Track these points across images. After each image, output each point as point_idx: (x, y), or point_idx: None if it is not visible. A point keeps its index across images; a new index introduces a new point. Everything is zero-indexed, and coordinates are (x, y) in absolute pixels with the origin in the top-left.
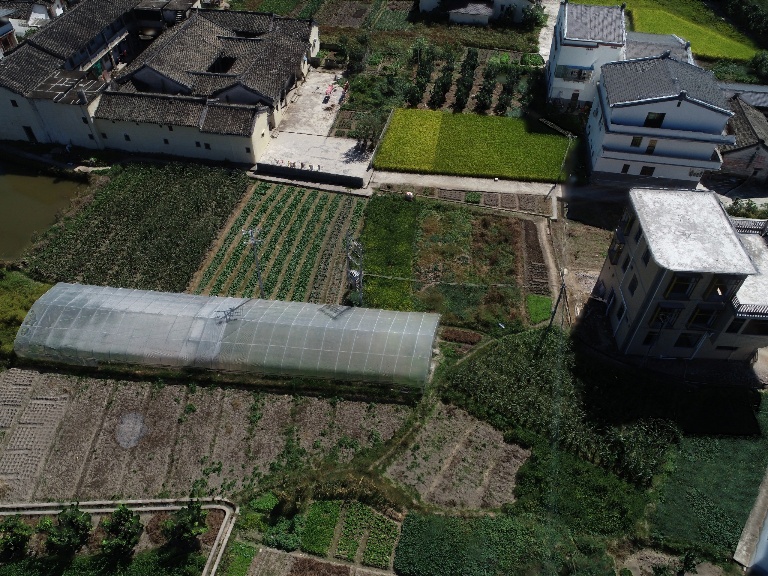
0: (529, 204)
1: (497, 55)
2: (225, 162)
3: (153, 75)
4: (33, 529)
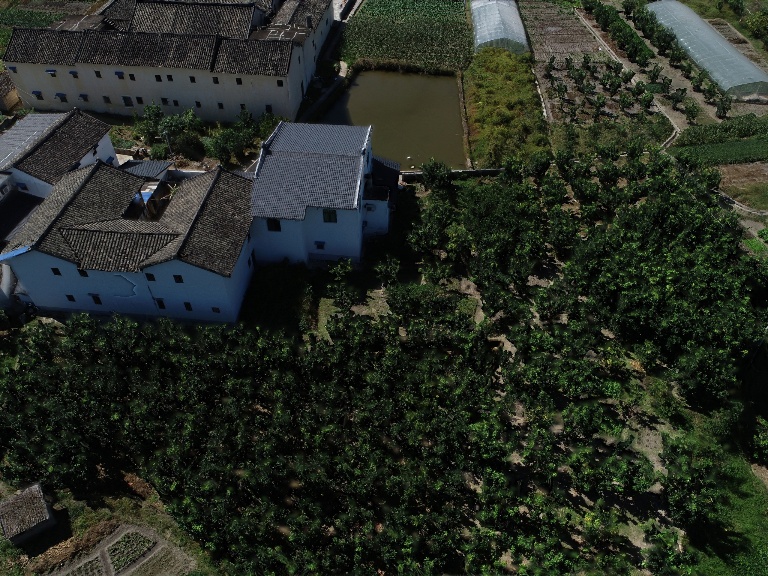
0: None
1: None
2: (334, 27)
3: (256, 14)
4: None
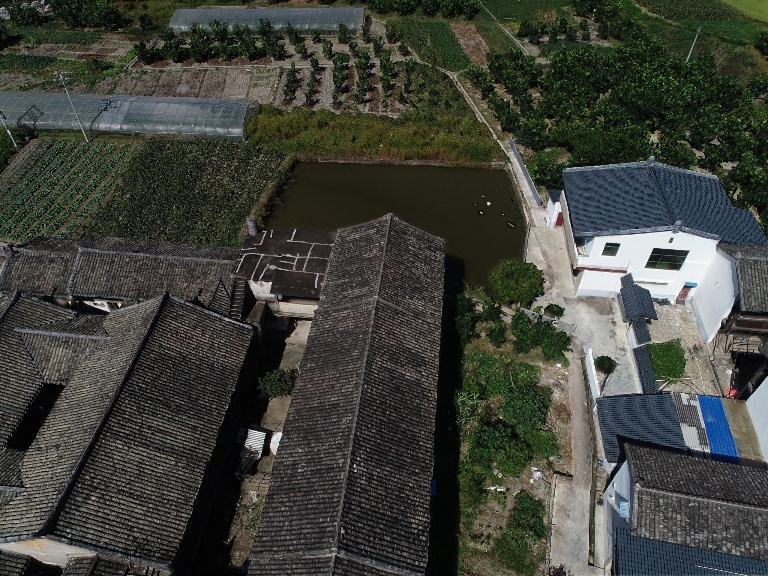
0: None
1: None
2: None
3: None
4: (215, 51)
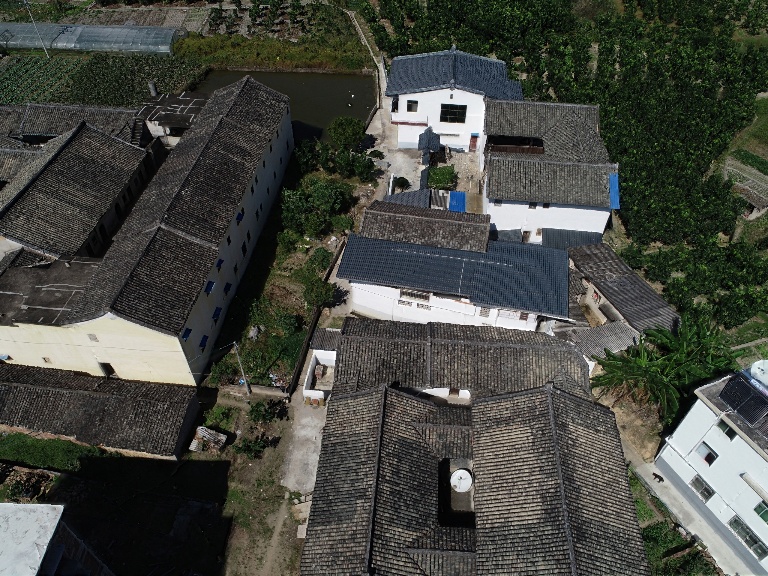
0: None
1: None
2: None
3: None
4: None
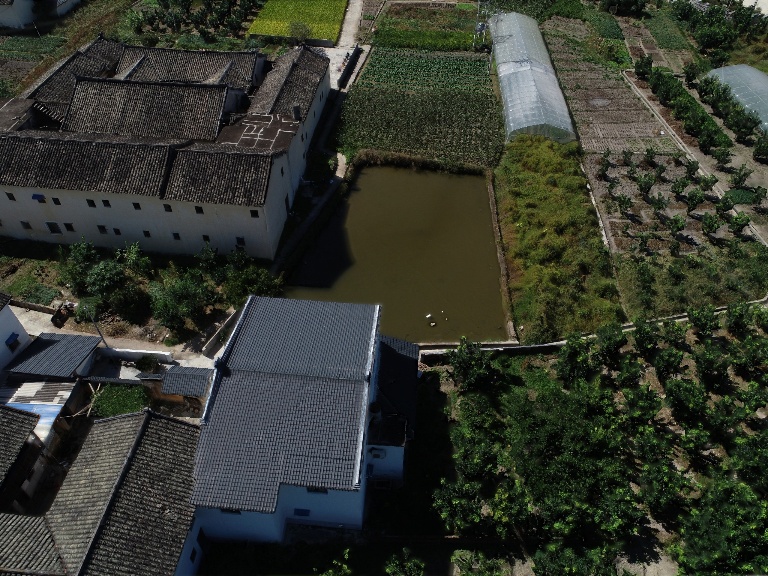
0: (374, 4)
1: (147, 4)
2: (330, 99)
3: None
4: None
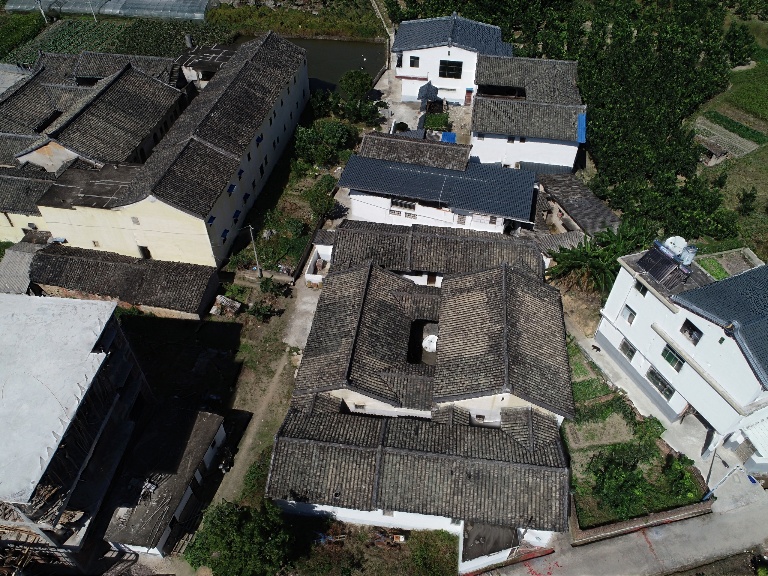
0: None
1: None
2: None
3: None
4: None
